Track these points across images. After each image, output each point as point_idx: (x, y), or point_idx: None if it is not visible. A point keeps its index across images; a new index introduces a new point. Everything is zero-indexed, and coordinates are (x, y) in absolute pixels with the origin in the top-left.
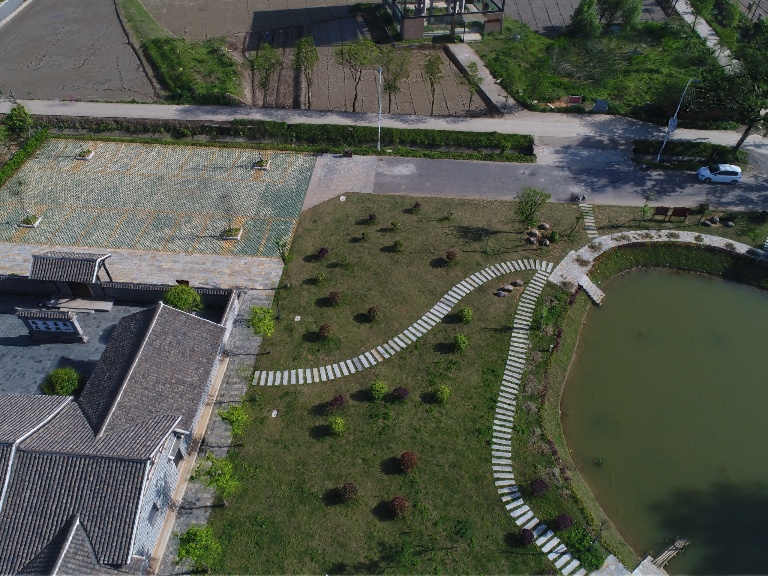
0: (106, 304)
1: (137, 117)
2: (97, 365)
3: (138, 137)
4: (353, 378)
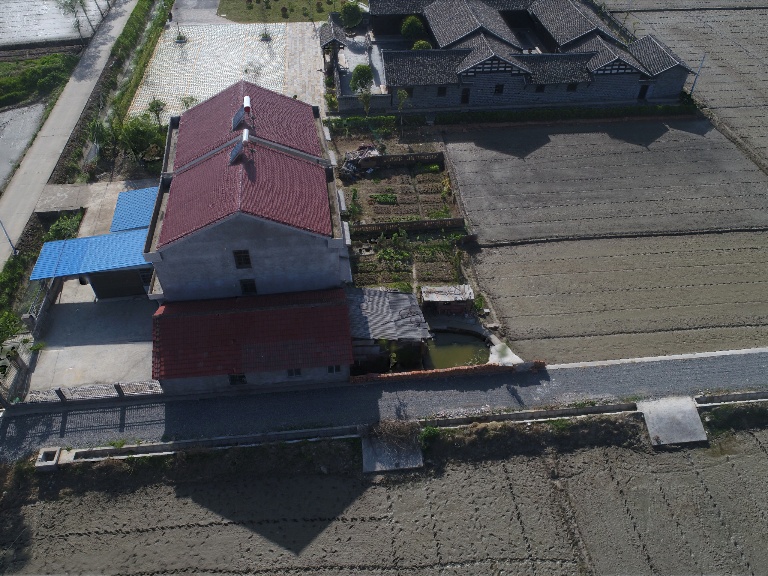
0: (340, 55)
1: (89, 95)
2: (402, 12)
3: (109, 107)
4: (366, 3)
